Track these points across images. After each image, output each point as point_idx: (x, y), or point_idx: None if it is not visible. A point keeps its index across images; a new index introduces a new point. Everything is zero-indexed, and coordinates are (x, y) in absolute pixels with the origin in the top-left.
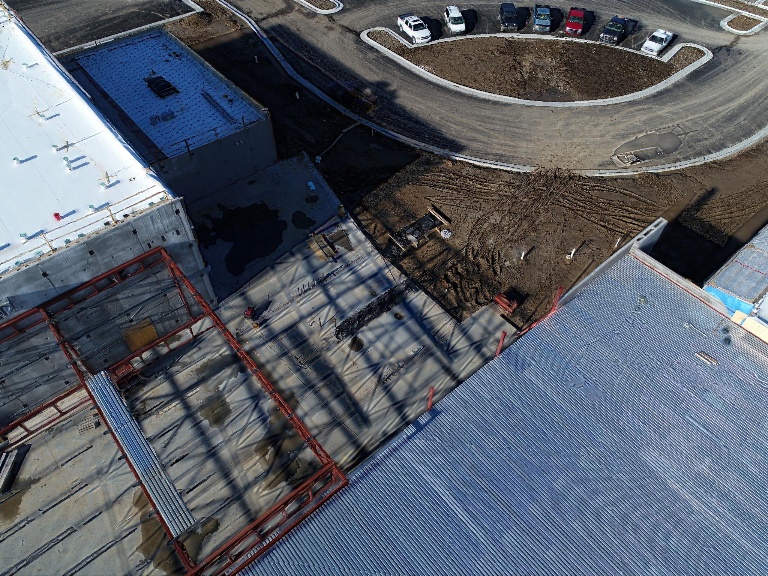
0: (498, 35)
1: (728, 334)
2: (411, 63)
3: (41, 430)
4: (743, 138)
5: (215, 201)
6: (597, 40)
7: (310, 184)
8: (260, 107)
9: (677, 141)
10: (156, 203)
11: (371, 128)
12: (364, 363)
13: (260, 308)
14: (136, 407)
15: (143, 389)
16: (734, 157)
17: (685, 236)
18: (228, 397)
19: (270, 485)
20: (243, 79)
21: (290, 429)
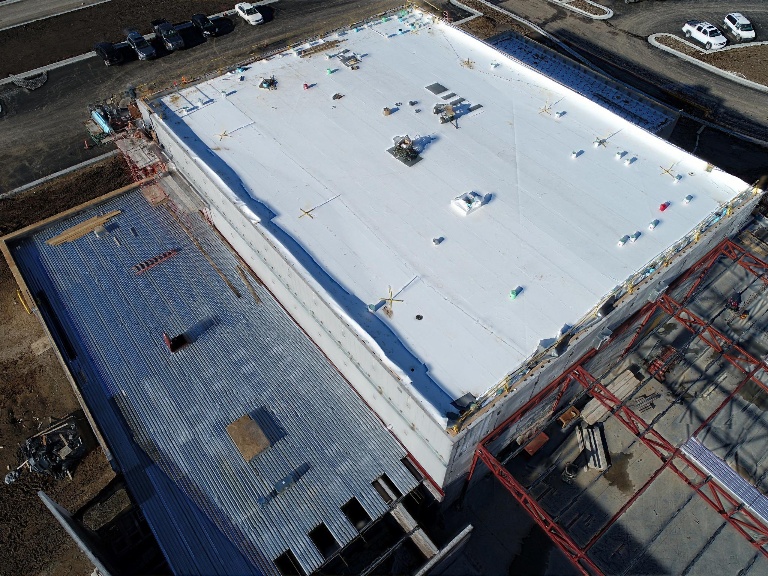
0: None
1: None
2: (717, 68)
3: None
4: None
5: None
6: None
7: None
8: (667, 108)
9: None
10: (748, 196)
11: (720, 130)
12: None
13: None
14: (678, 390)
15: (674, 373)
16: None
17: None
18: None
19: None
20: None
21: None
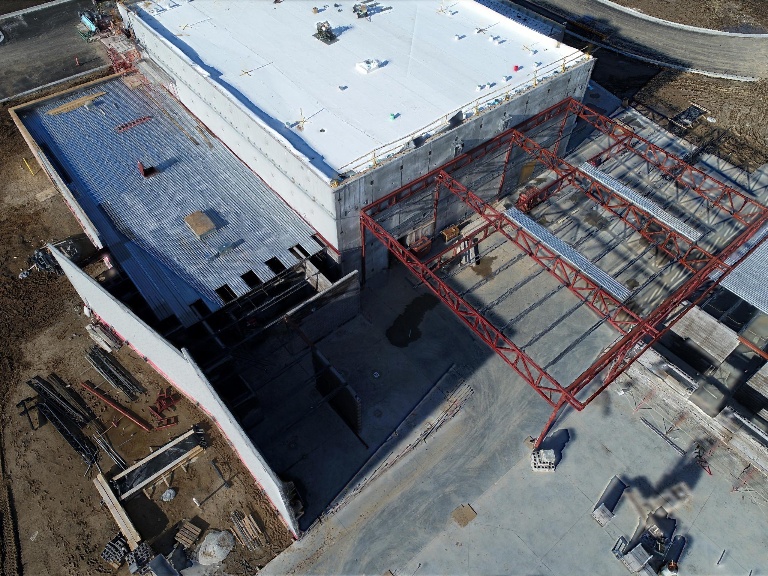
0: None
1: None
2: (620, 5)
3: None
4: None
5: None
6: None
7: None
8: (556, 23)
9: None
10: (582, 61)
11: (612, 50)
12: (692, 196)
13: None
14: None
15: (538, 209)
16: None
17: None
18: (603, 214)
19: (662, 262)
20: None
21: None
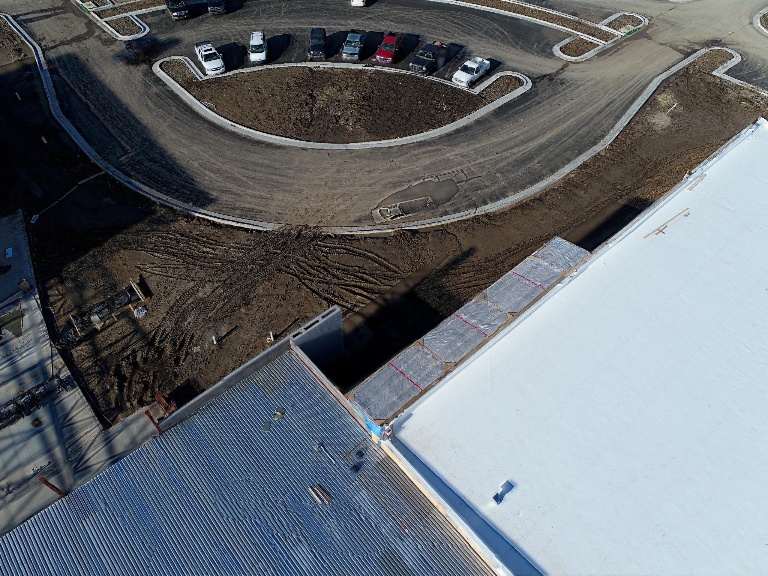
0: (302, 64)
1: (361, 459)
2: (194, 98)
3: None
4: (528, 185)
5: None
6: None
7: (8, 251)
8: None
9: (454, 190)
10: None
11: (114, 178)
12: None
13: None
14: None
15: None
16: (510, 209)
17: (416, 310)
18: None
19: None
20: None
21: None
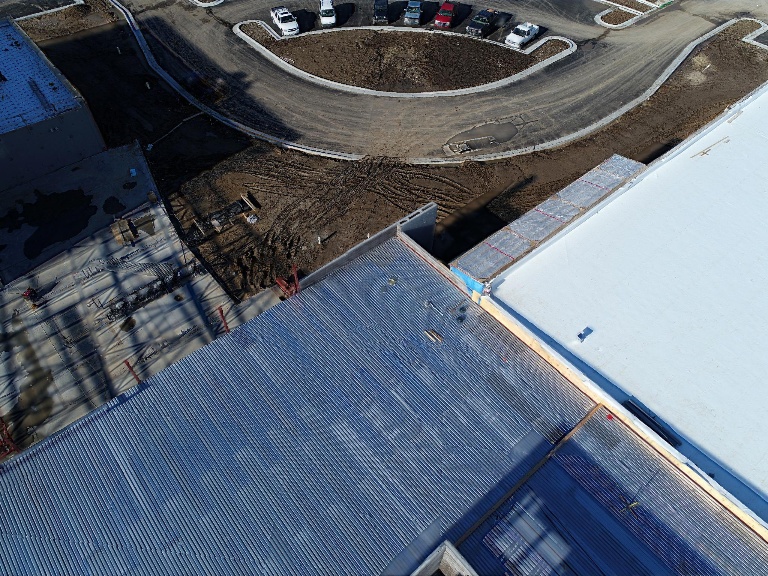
0: (368, 28)
1: (464, 313)
2: (274, 55)
3: None
4: (580, 128)
5: (33, 187)
6: (465, 33)
7: (132, 171)
8: (78, 94)
9: (513, 131)
10: None
11: (213, 117)
12: (130, 343)
13: (44, 290)
14: None
15: None
16: (564, 146)
17: (489, 222)
18: None
19: None
20: (101, 69)
21: (36, 405)
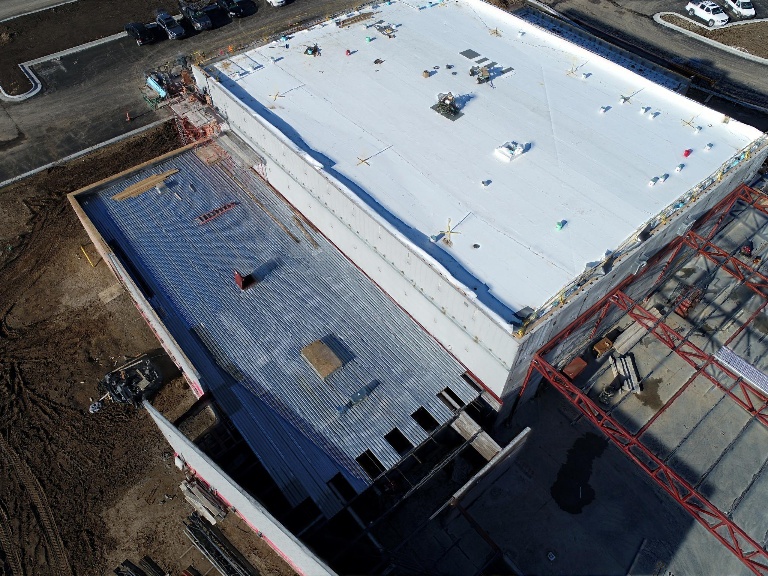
0: None
1: None
2: (721, 43)
3: (637, 341)
4: None
5: None
6: None
7: None
8: (680, 75)
9: None
10: (763, 143)
11: (726, 99)
12: None
13: None
14: None
15: (695, 310)
16: None
17: None
18: None
19: None
20: None
21: None
